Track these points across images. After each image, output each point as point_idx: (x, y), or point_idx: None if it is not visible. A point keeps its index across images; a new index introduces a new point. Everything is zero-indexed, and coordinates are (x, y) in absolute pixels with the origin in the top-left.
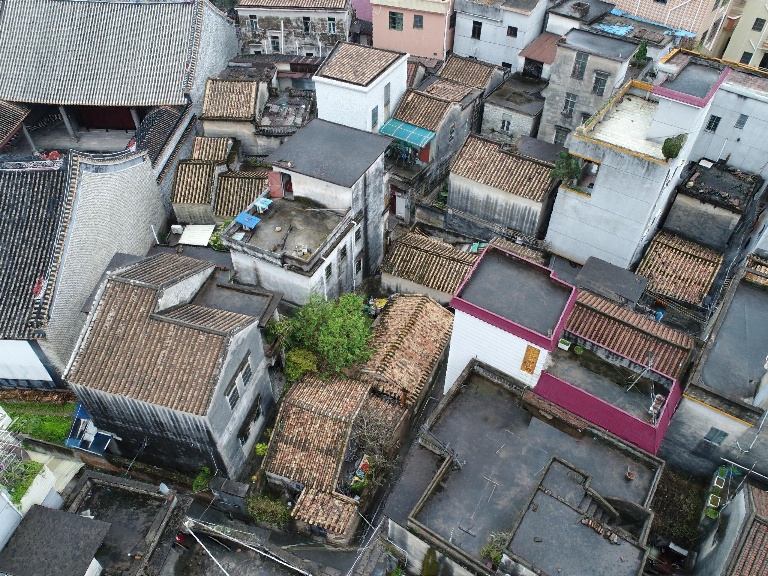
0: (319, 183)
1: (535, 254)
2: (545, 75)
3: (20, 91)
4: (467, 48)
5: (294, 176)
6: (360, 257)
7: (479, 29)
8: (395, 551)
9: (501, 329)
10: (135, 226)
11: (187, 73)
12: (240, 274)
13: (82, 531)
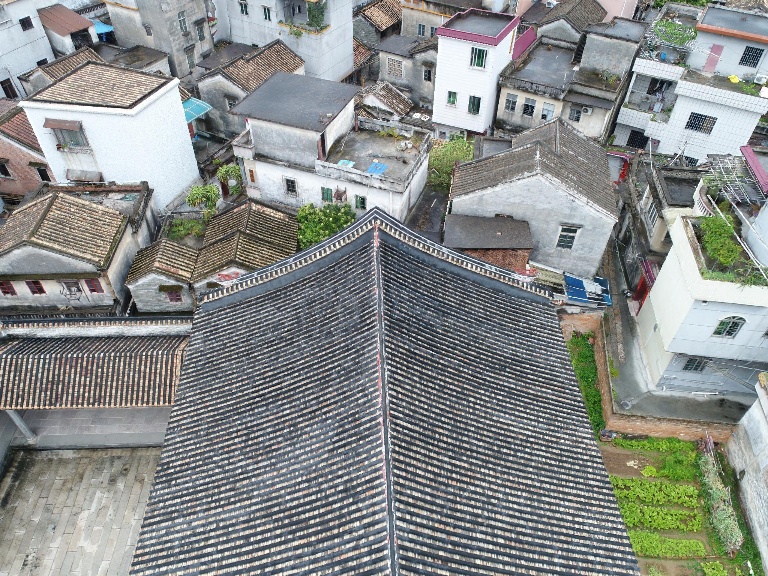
0: None
1: None
2: (96, 38)
3: None
4: None
5: None
6: None
7: None
8: None
9: None
10: None
11: None
12: None
13: None
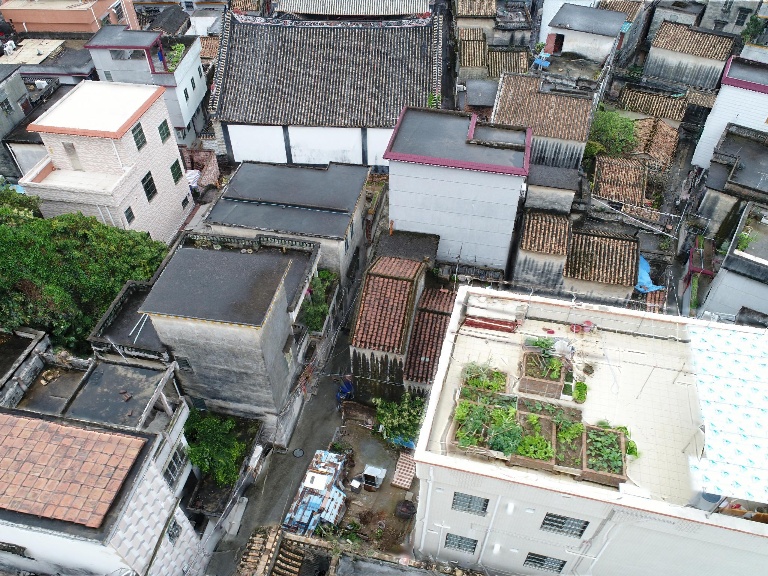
0: (587, 39)
1: None
2: None
3: (304, 6)
4: None
5: (568, 36)
6: (600, 99)
7: None
8: (698, 225)
9: (759, 92)
10: None
11: None
12: None
13: (565, 172)
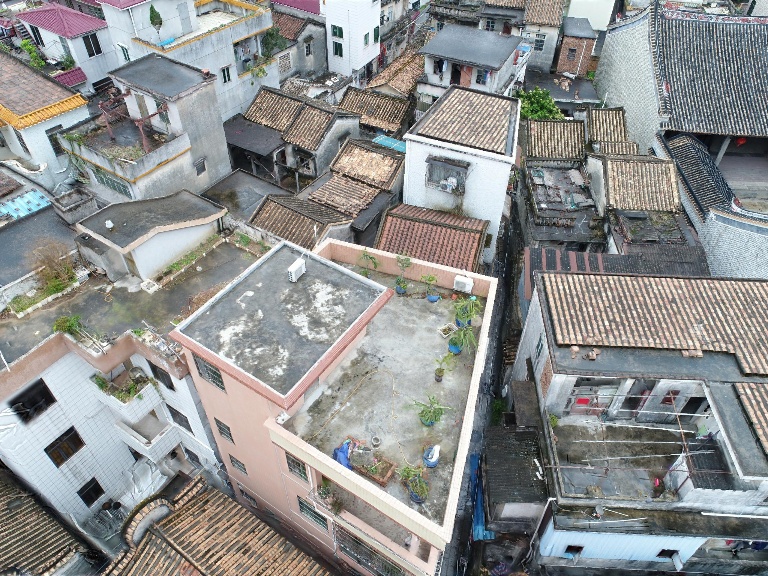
0: None
1: None
2: None
3: None
4: None
5: None
6: None
7: None
8: None
9: None
10: None
11: None
12: None
13: None
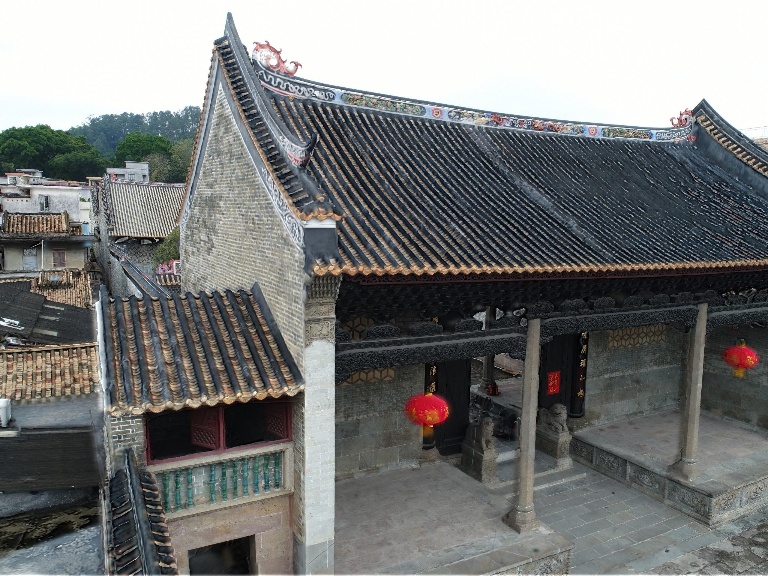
0: None
1: None
2: None
3: None
4: None
5: None
6: None
7: None
8: None
9: None
10: None
11: None
12: None
13: None
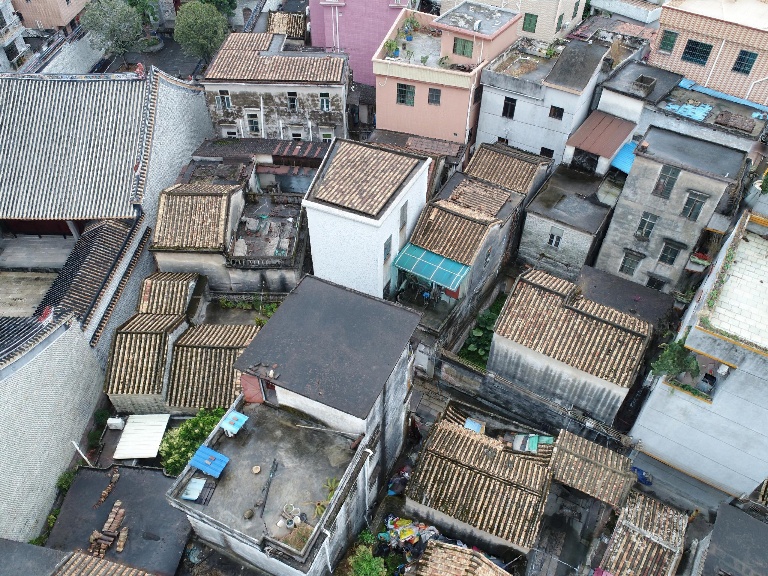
0: None
1: (622, 463)
2: (601, 170)
3: None
4: (496, 128)
5: None
6: (375, 475)
7: (512, 107)
8: None
9: None
10: (54, 426)
11: (136, 176)
12: (200, 531)
13: None
